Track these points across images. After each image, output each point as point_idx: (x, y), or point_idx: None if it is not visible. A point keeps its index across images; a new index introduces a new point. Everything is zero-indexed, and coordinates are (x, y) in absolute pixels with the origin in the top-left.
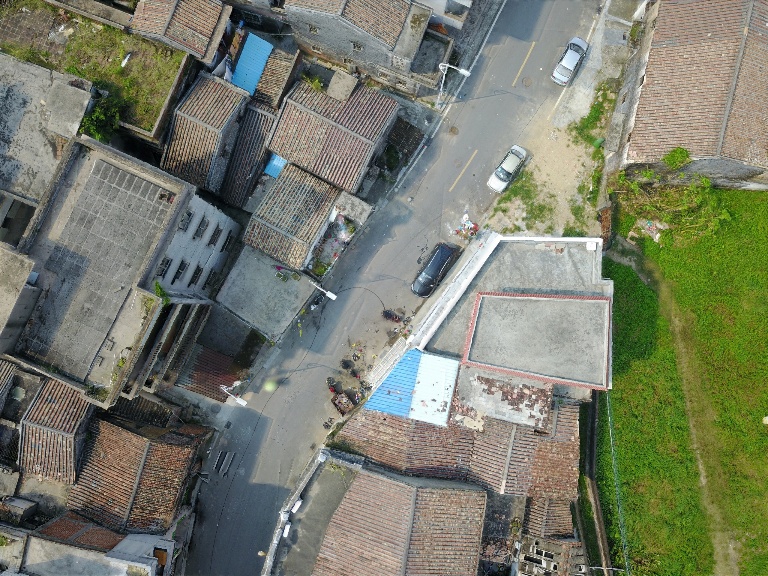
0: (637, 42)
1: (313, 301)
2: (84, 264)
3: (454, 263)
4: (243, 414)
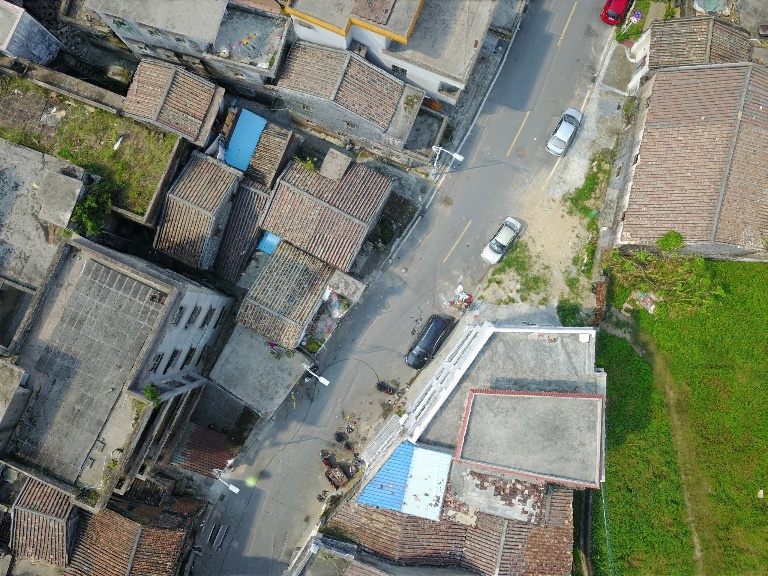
0: (631, 117)
1: (307, 373)
2: (75, 365)
3: (448, 335)
4: None
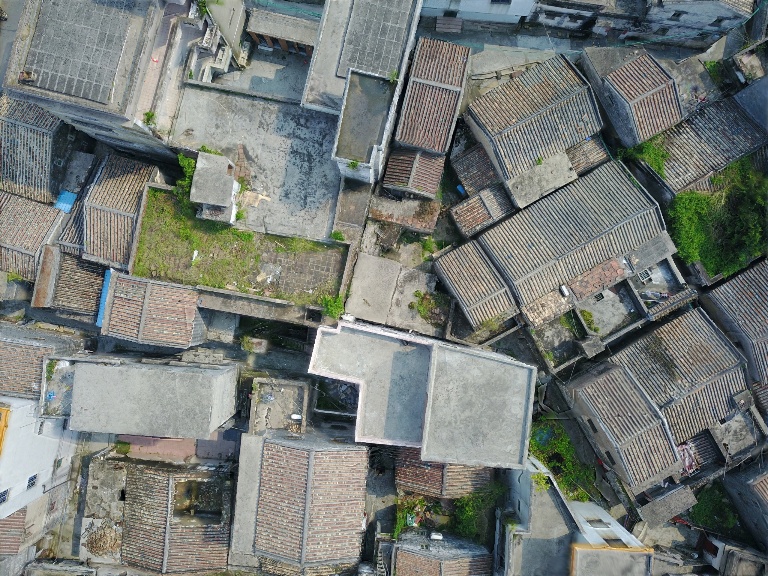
0: None
1: None
2: None
3: None
4: None
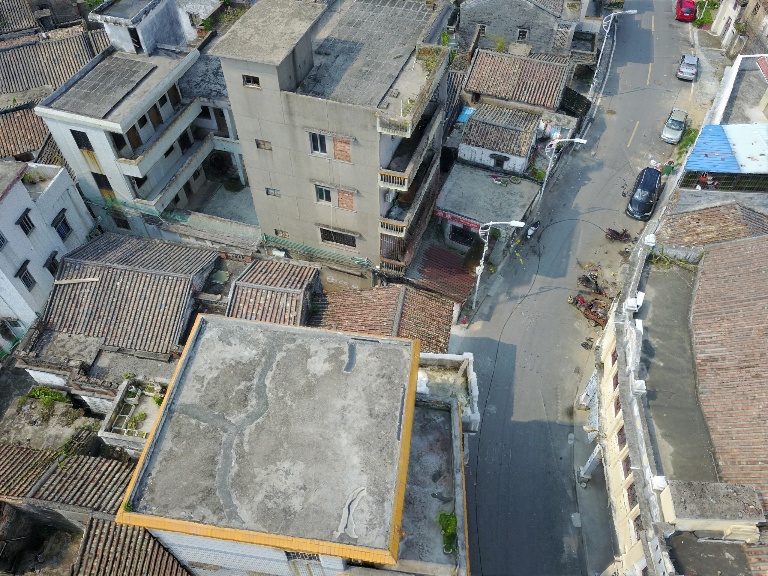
0: (744, 31)
1: (526, 231)
2: (357, 46)
3: (661, 192)
4: (476, 344)
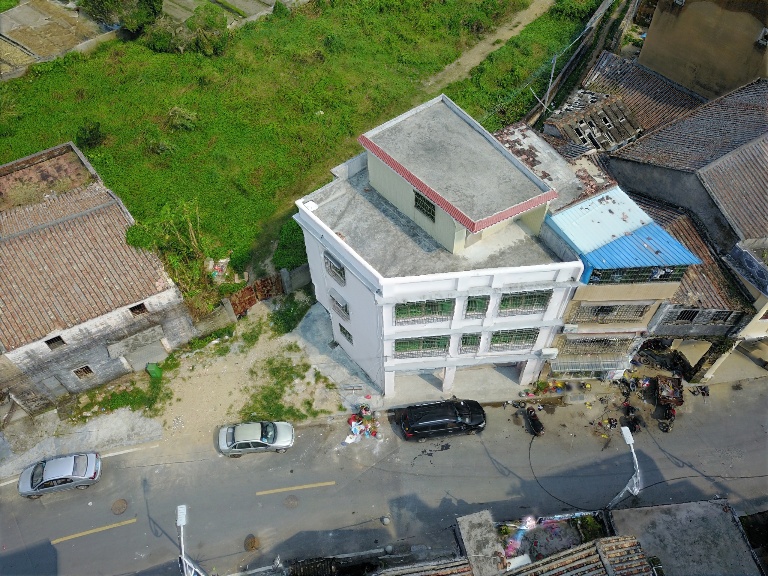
0: None
1: None
2: None
3: None
4: None
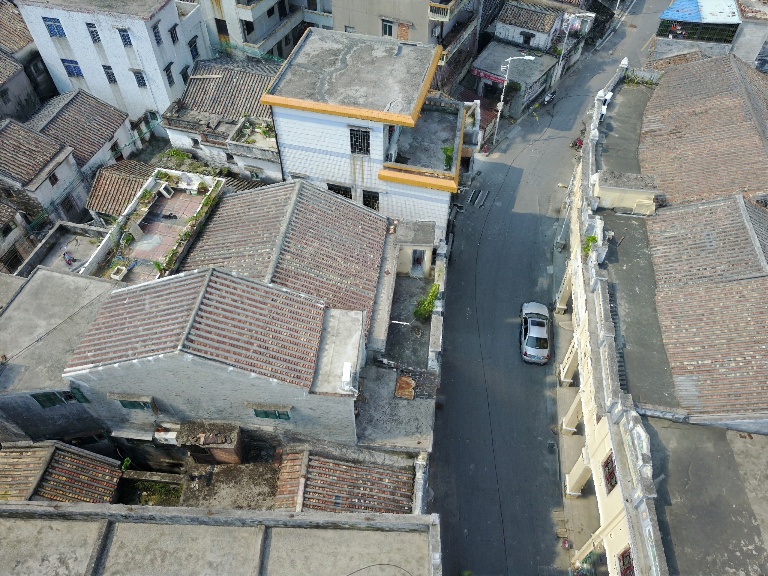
0: None
1: None
2: None
3: None
4: (492, 166)
